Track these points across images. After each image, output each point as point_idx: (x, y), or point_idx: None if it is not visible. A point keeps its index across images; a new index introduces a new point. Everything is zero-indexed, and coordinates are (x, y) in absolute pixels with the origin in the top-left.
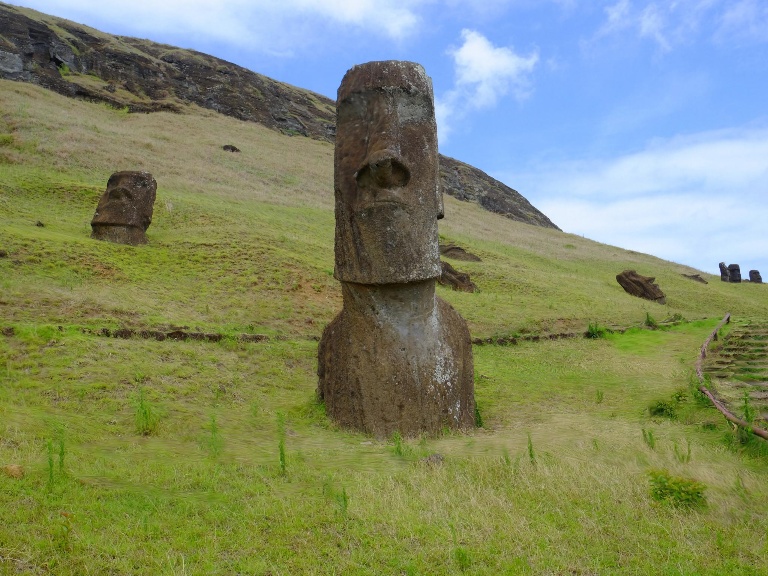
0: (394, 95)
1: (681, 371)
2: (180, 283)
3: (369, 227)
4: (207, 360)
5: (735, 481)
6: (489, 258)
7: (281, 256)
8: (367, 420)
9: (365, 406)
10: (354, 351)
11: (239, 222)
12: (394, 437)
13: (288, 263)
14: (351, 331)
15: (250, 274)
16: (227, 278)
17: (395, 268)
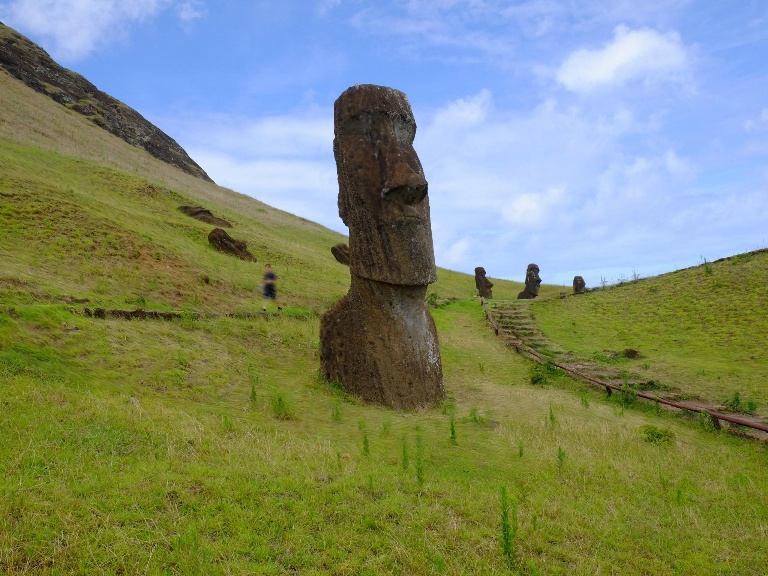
0: (394, 120)
1: (498, 346)
2: (12, 242)
3: (398, 237)
4: (189, 341)
5: (668, 427)
6: (232, 223)
7: (96, 216)
8: (387, 396)
9: (384, 384)
10: (370, 338)
11: (3, 165)
12: (408, 408)
13: (109, 225)
14: (366, 321)
15: (82, 236)
16: (60, 239)
17: (418, 273)
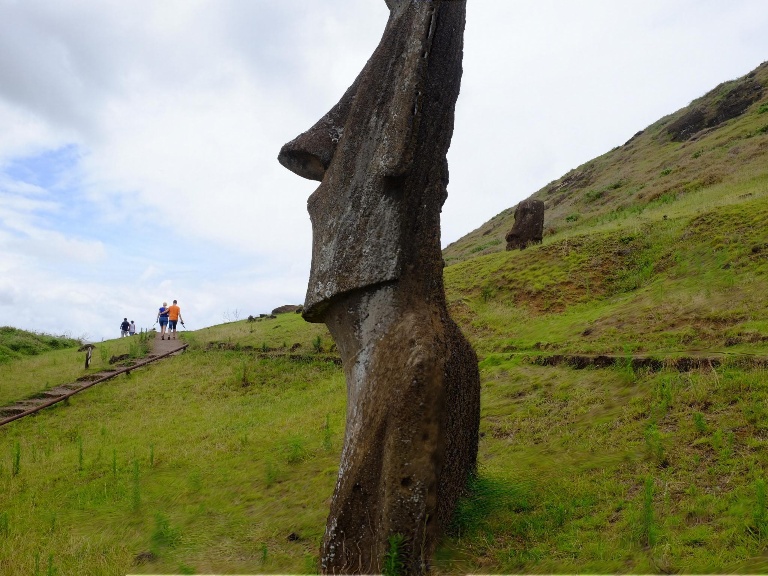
0: (390, 3)
1: None
2: None
3: None
4: (558, 398)
5: None
6: None
7: None
8: None
9: None
10: None
11: None
12: None
13: None
14: None
15: None
16: None
17: None
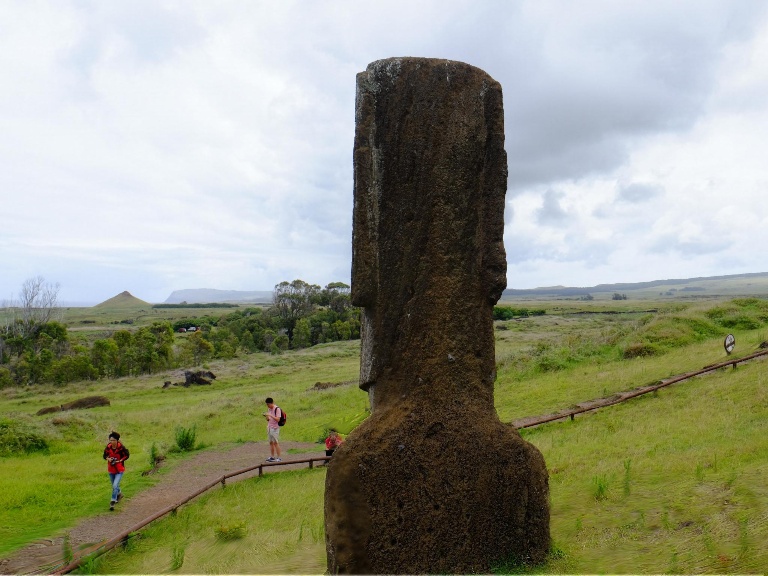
0: None
1: None
2: None
3: None
4: None
5: None
6: None
7: None
8: None
9: None
10: None
11: None
12: None
13: None
14: None
15: None
16: None
17: None
